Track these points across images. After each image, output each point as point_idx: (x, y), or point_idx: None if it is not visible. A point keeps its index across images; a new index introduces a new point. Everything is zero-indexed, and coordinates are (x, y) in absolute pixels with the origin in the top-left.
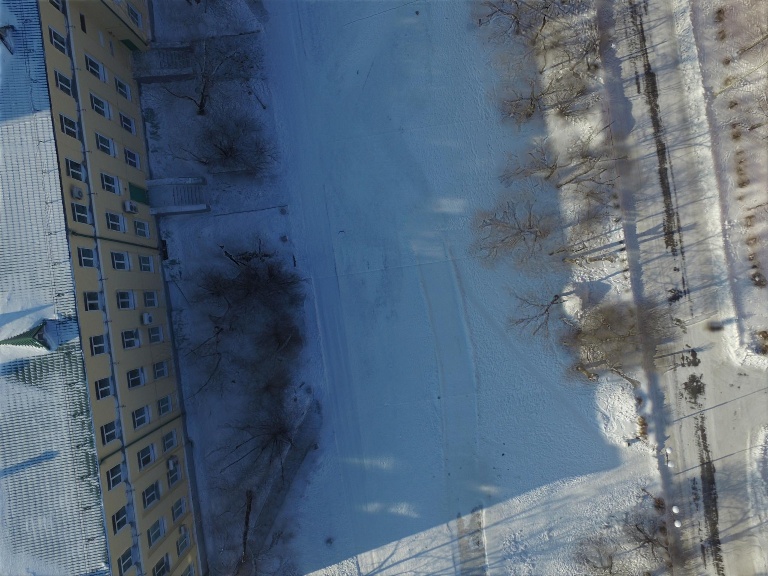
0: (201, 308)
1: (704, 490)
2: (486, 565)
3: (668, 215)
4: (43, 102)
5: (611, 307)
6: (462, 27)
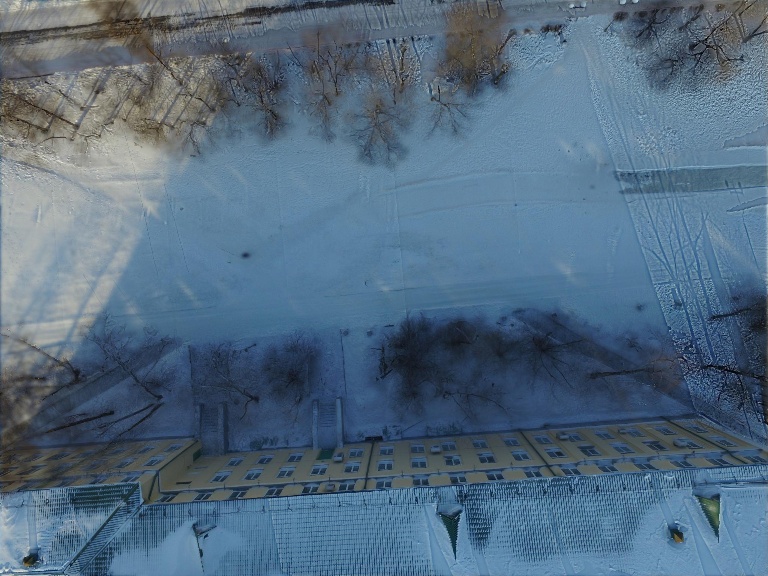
0: None
1: None
2: (667, 170)
3: (366, 2)
4: (256, 504)
5: (444, 53)
6: (196, 171)
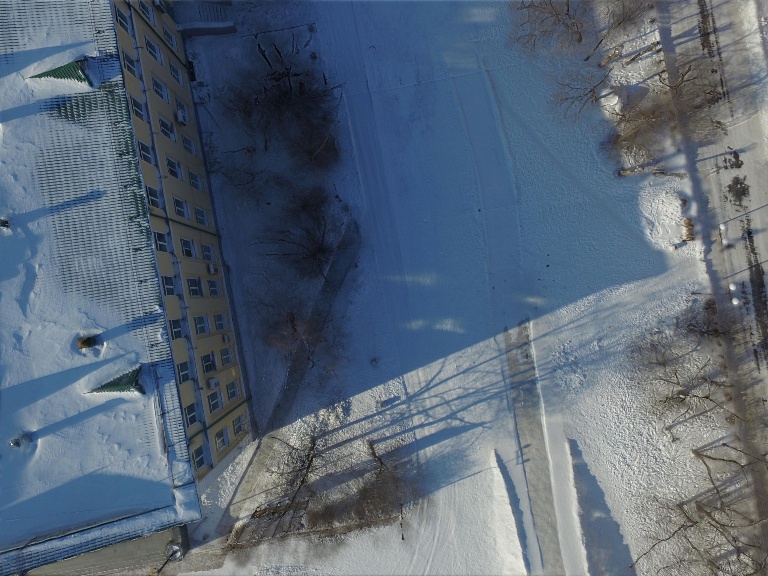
0: (232, 130)
1: (754, 293)
2: (536, 378)
3: (703, 16)
4: None
5: (651, 108)
6: None
